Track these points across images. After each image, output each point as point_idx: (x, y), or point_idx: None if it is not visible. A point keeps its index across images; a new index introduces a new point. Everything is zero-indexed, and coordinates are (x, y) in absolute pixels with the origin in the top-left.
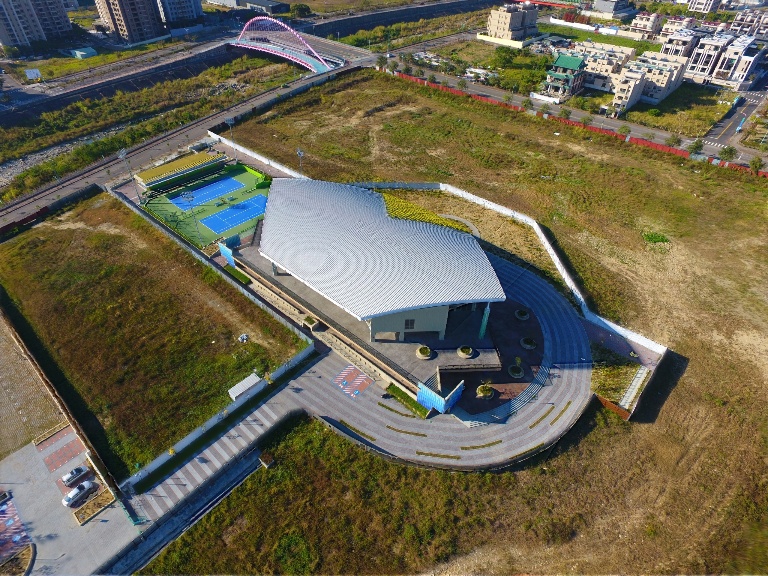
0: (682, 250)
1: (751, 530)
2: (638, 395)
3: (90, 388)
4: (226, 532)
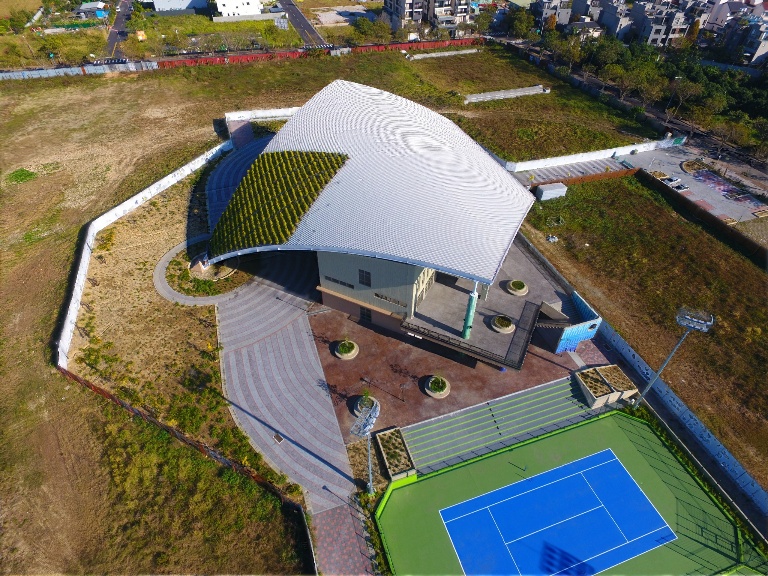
0: (34, 160)
1: (310, 87)
2: (278, 117)
3: (711, 242)
4: (564, 149)
